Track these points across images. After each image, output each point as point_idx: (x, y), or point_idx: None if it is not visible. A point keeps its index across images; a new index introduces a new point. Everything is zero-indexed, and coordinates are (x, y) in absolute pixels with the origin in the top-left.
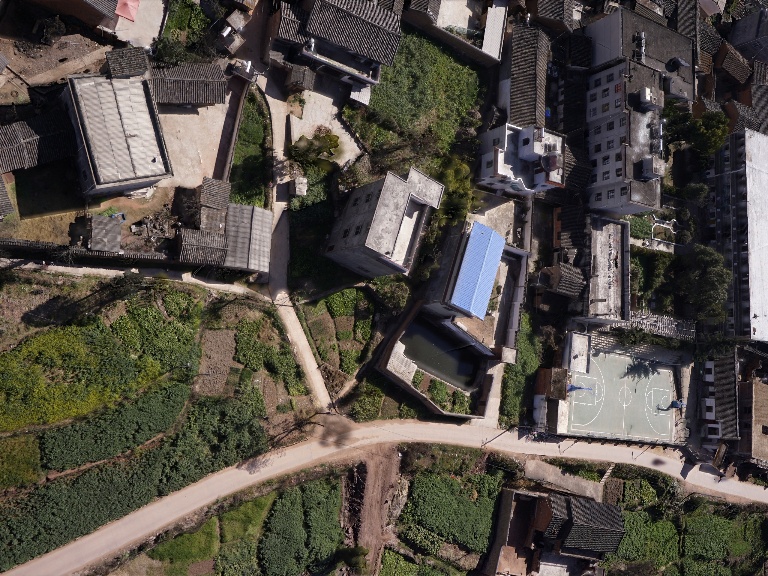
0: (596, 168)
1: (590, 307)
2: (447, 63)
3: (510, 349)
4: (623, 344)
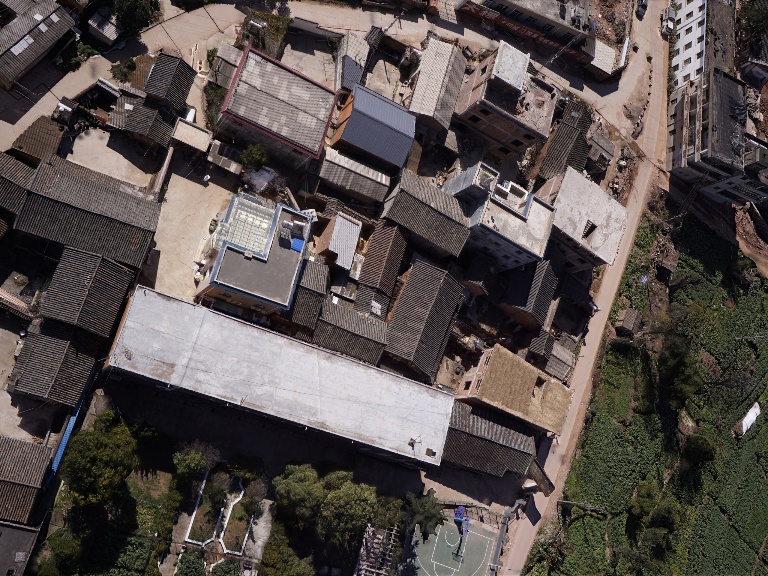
0: None
1: None
2: None
3: None
4: None
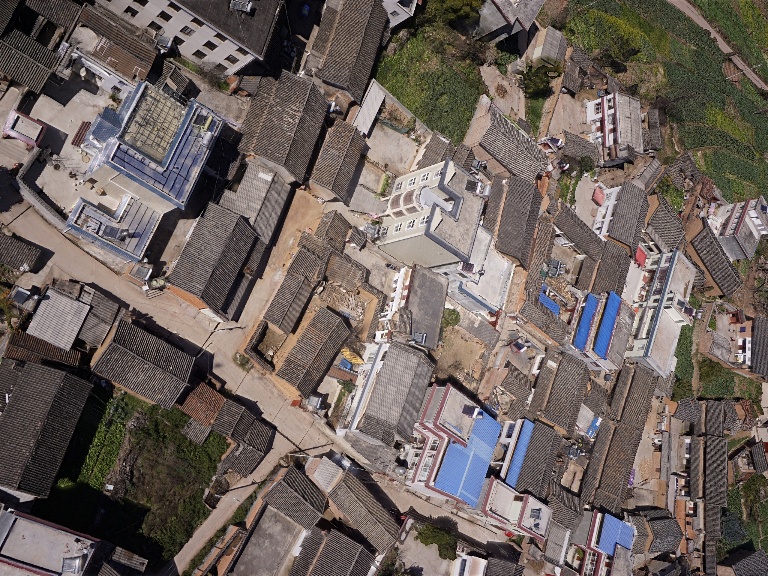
0: None
1: None
2: (404, 104)
3: None
4: None
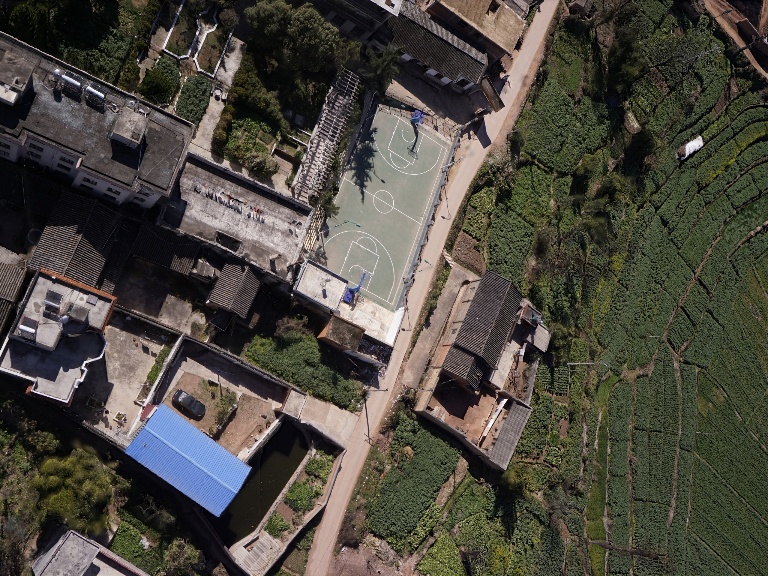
0: (95, 190)
1: (278, 267)
2: None
3: (288, 399)
4: (333, 213)
